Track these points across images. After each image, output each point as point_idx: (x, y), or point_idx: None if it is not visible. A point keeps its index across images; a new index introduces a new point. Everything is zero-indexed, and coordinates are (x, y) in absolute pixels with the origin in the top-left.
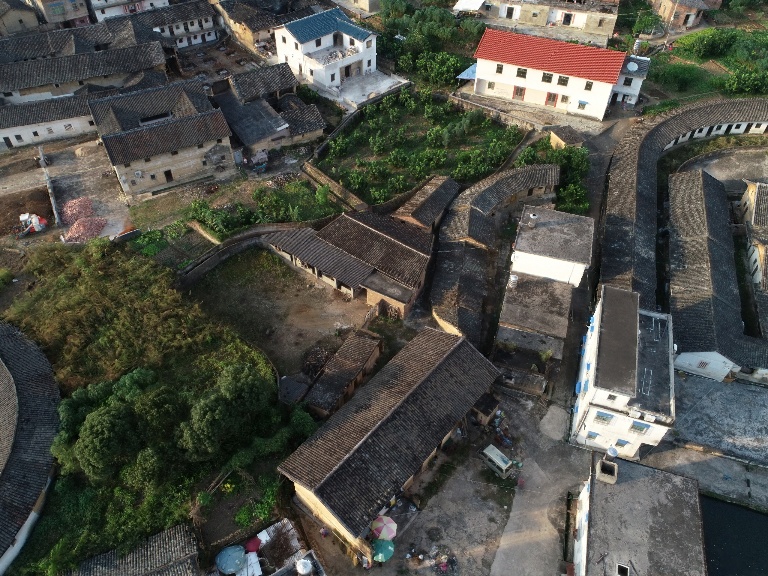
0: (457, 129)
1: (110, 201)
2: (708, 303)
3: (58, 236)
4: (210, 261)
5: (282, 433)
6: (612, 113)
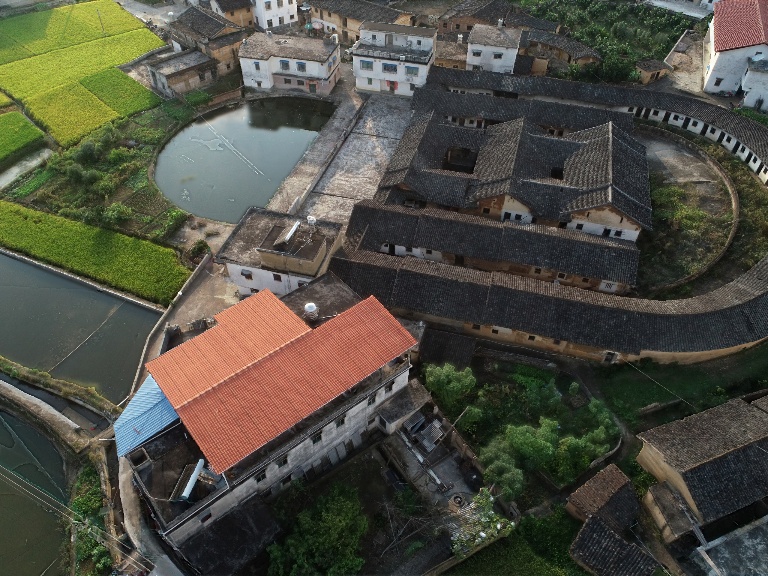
0: None
1: None
2: None
3: None
4: None
5: None
6: (725, 98)
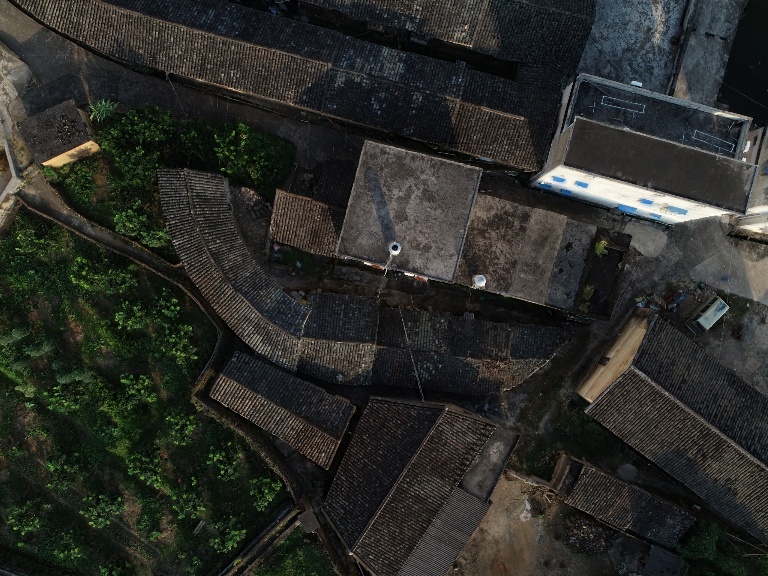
0: (40, 354)
1: None
2: (504, 2)
3: None
4: None
5: (730, 568)
6: None
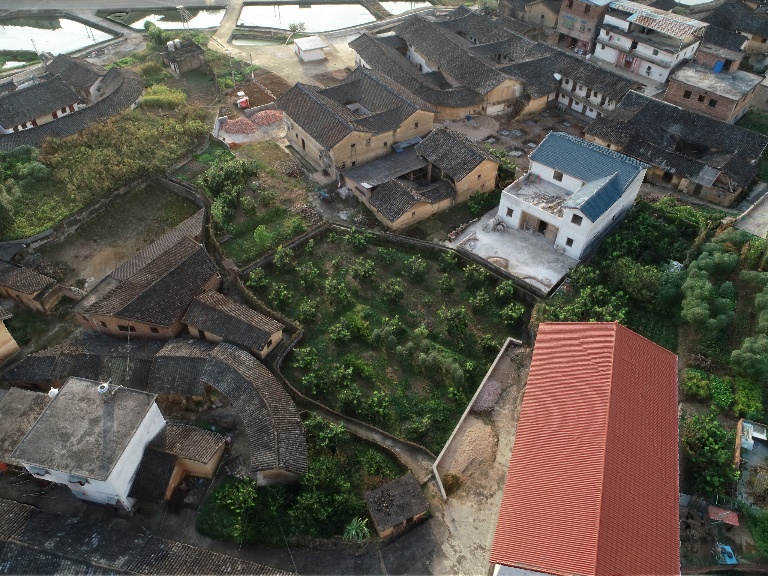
0: None
1: (280, 129)
2: None
3: (234, 117)
4: (180, 188)
5: None
6: None
